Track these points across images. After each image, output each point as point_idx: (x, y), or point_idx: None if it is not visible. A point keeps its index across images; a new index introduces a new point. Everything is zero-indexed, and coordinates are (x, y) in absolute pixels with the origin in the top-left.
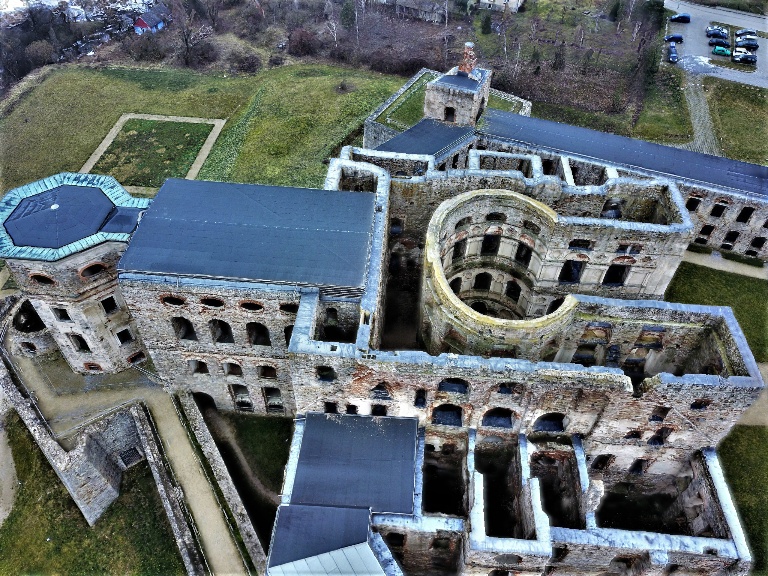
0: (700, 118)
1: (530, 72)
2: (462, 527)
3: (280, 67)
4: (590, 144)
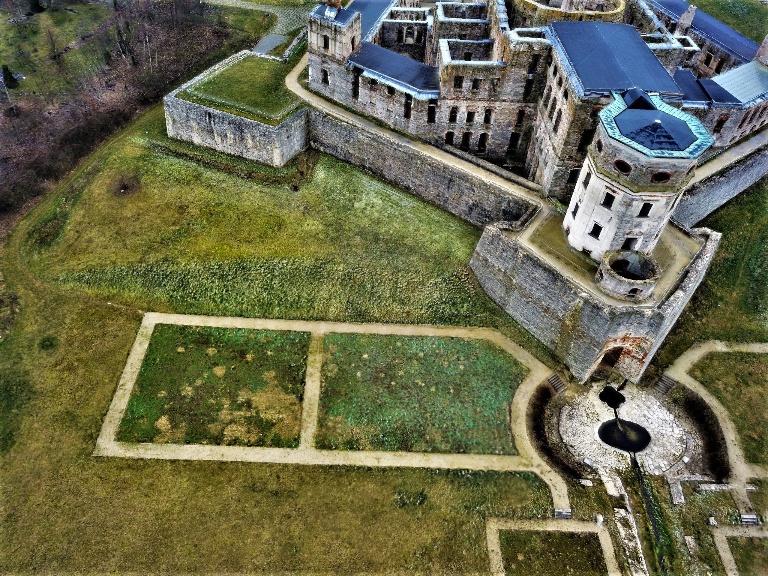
0: (245, 5)
1: (130, 67)
2: (681, 66)
3: (1, 271)
4: (371, 8)
